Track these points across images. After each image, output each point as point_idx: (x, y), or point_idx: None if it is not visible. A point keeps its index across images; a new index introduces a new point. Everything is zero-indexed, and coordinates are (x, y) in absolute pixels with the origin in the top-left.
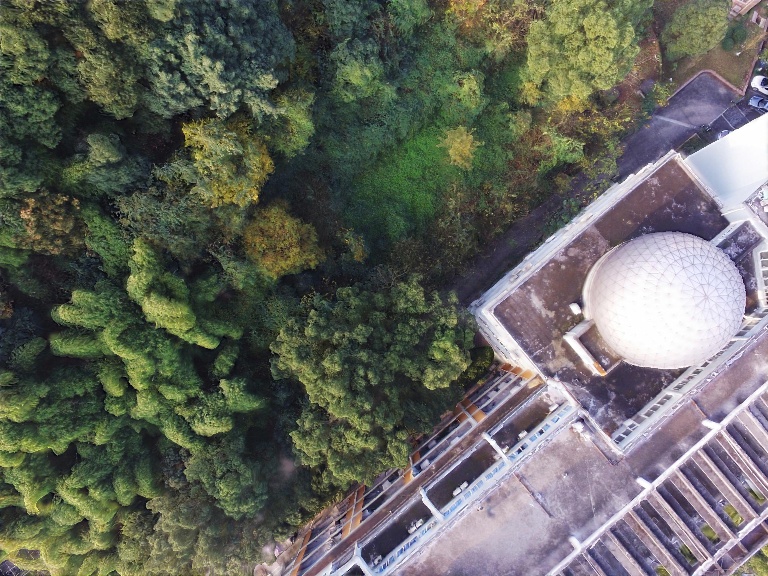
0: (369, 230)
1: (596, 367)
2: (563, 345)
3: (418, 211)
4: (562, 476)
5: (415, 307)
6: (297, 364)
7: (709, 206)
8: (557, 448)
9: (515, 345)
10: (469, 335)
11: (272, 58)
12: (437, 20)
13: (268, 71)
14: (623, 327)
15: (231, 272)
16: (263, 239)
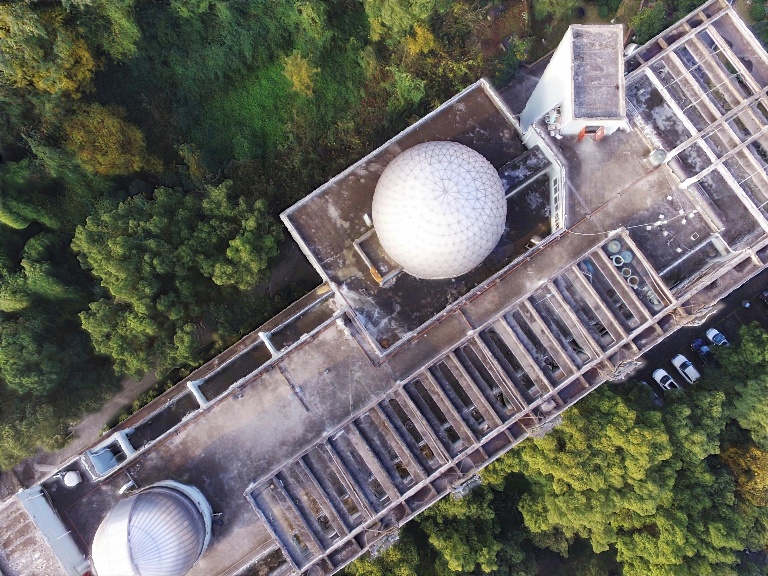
0: (216, 150)
1: (373, 272)
2: (354, 255)
3: (268, 138)
4: (324, 372)
5: (219, 208)
6: (86, 244)
7: (511, 134)
8: (322, 345)
9: (306, 250)
10: (267, 239)
11: None
12: None
13: None
14: (382, 225)
15: (42, 157)
16: (80, 131)
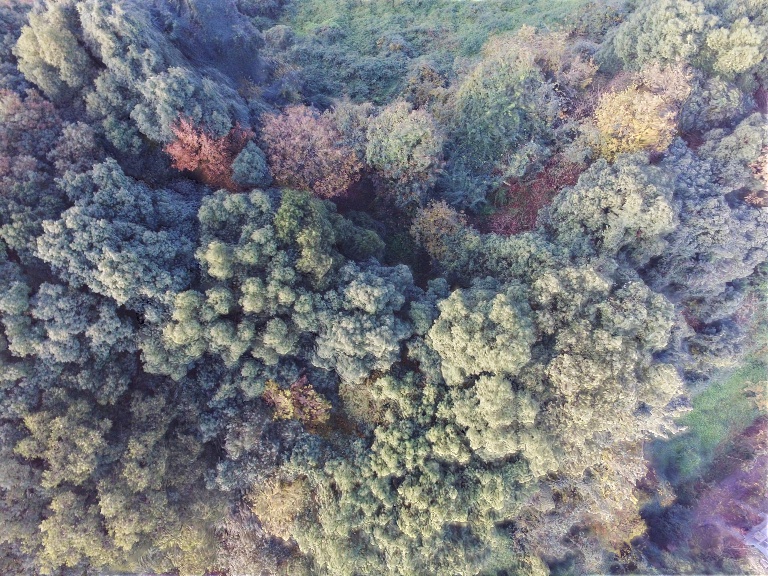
0: (659, 461)
1: None
2: None
3: (704, 440)
4: None
5: None
6: None
7: None
8: None
9: None
10: None
11: None
12: None
13: (685, 401)
14: None
15: None
16: (614, 520)
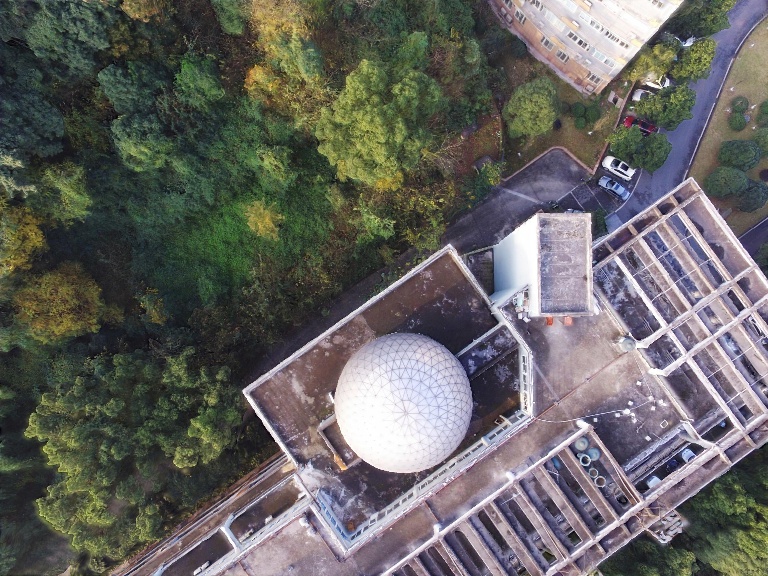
0: (181, 290)
1: (337, 461)
2: None
3: (234, 274)
4: (288, 569)
5: (180, 382)
6: (40, 434)
7: (480, 304)
8: (286, 540)
9: (270, 429)
10: (230, 414)
11: (19, 138)
12: (245, 93)
13: (10, 151)
14: (344, 430)
15: None
16: (32, 304)
